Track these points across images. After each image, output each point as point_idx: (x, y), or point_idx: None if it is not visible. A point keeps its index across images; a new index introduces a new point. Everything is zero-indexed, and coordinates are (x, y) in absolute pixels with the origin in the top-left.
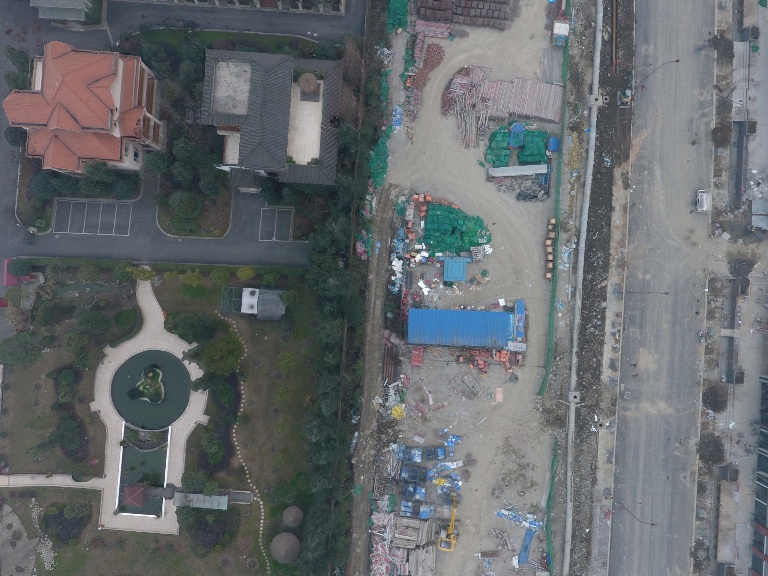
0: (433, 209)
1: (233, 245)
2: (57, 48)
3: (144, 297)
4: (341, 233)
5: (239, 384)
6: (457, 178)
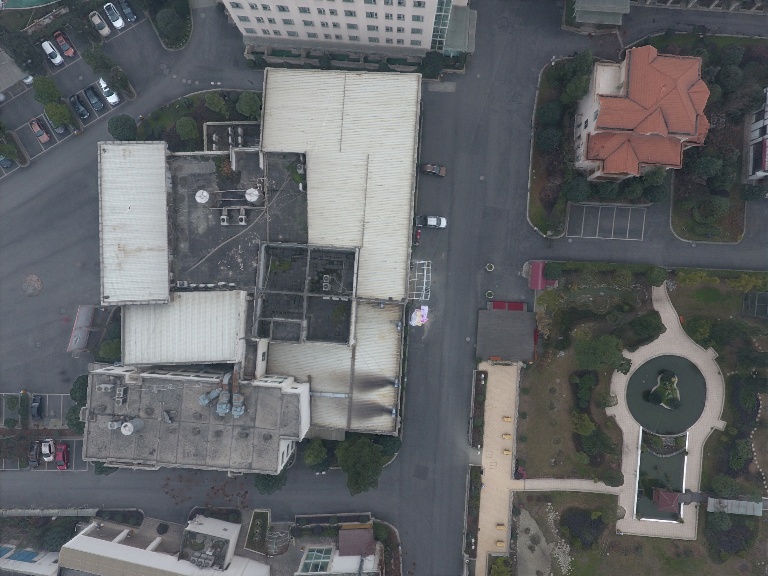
0: None
1: (748, 250)
2: (651, 53)
3: (659, 302)
4: None
5: None
6: None
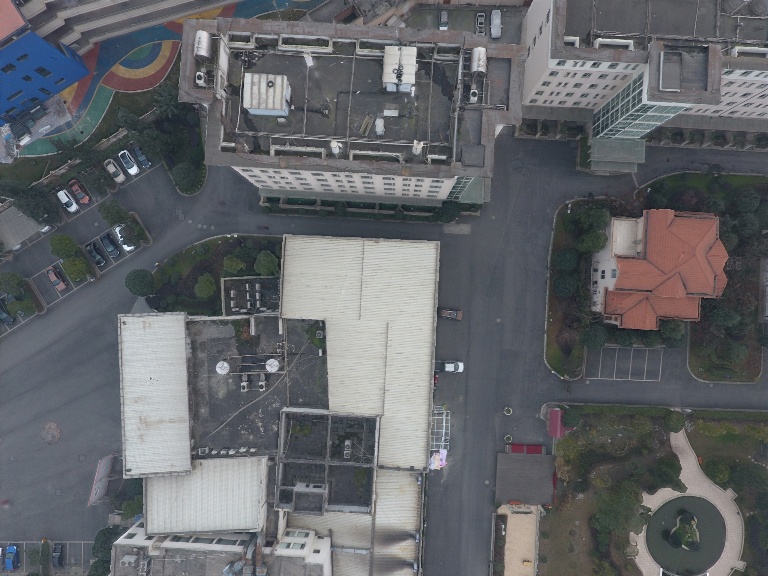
0: None
1: (765, 390)
2: (669, 216)
3: (677, 443)
4: None
5: None
6: None
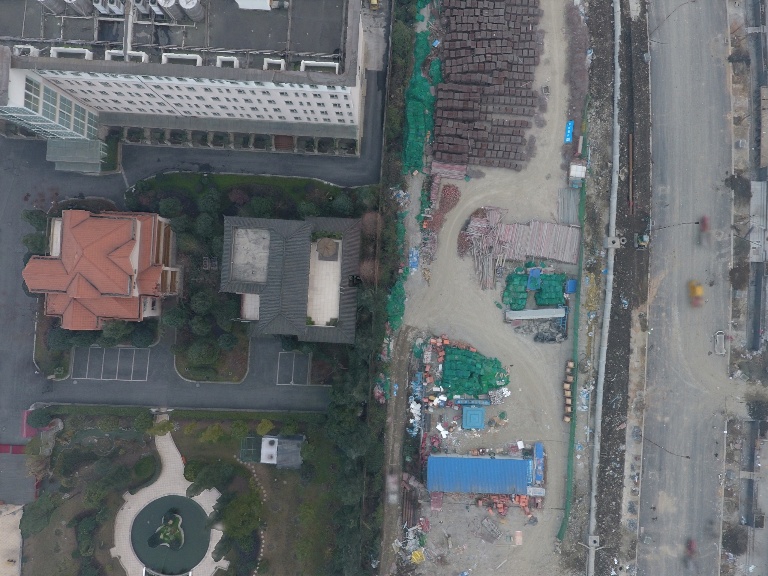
0: (451, 353)
1: (251, 390)
2: (76, 216)
3: (163, 442)
4: (361, 395)
5: (259, 529)
6: (474, 320)
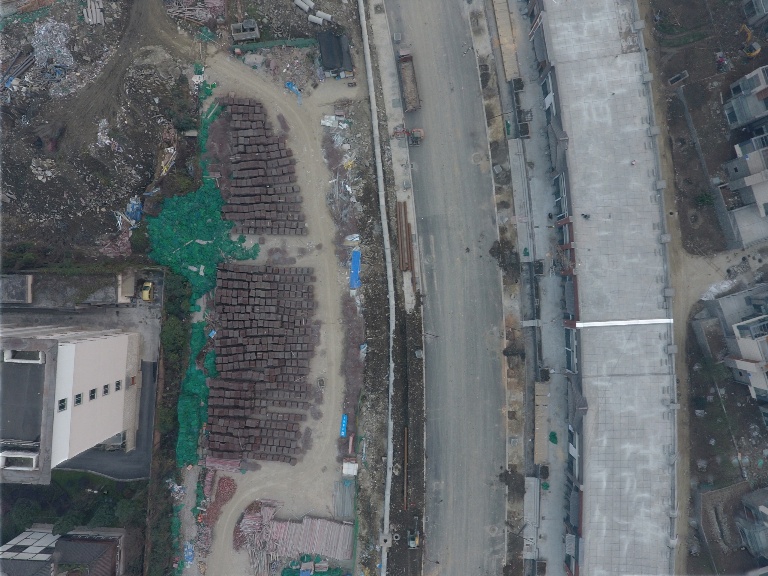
0: None
1: None
2: None
3: None
4: None
5: None
6: None
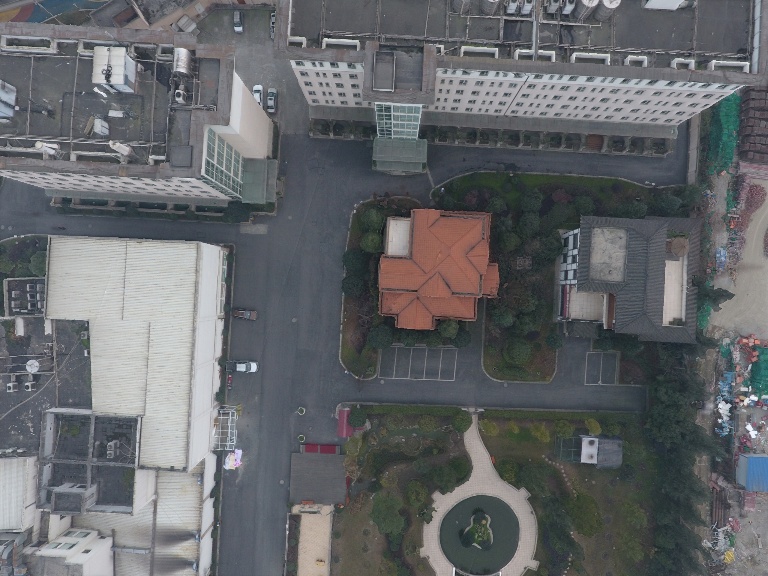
0: (763, 353)
1: (559, 389)
2: (431, 216)
3: (471, 442)
4: None
5: None
6: None
